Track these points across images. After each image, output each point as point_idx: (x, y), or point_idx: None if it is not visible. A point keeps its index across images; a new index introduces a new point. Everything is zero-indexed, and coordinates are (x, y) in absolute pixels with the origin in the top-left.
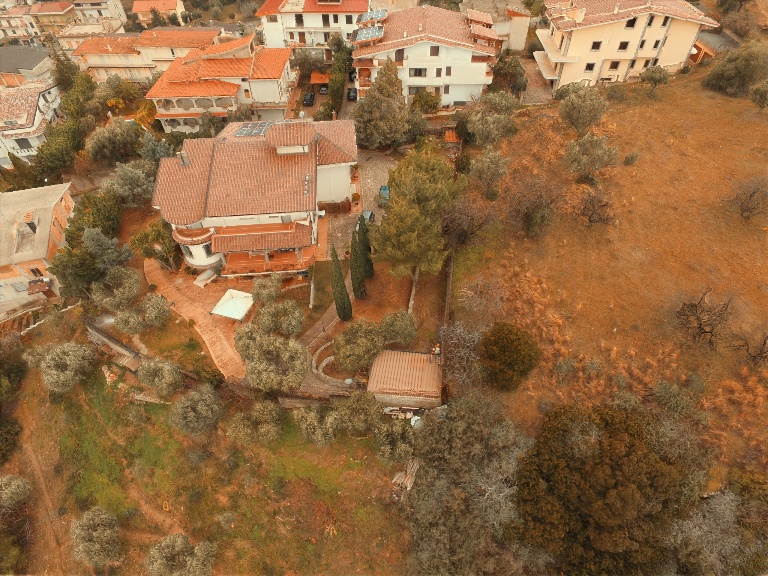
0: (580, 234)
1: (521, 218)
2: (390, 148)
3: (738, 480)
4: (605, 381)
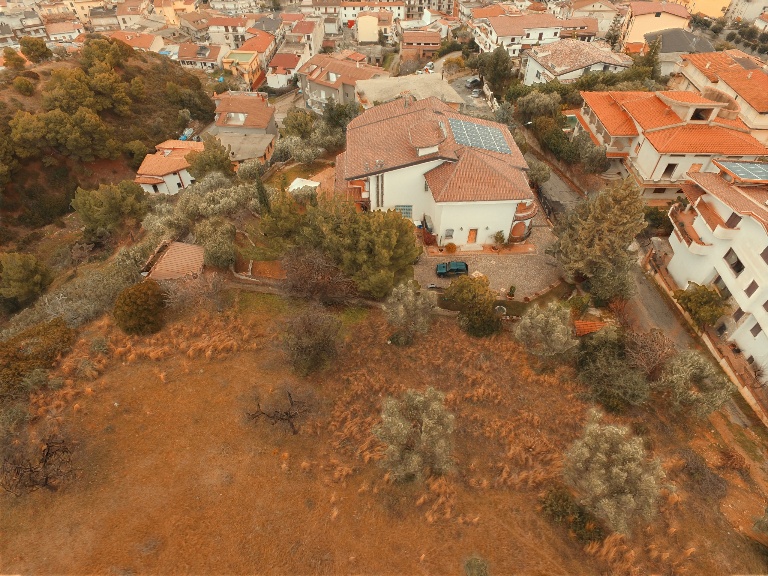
0: None
1: None
2: (580, 282)
3: None
4: (73, 381)
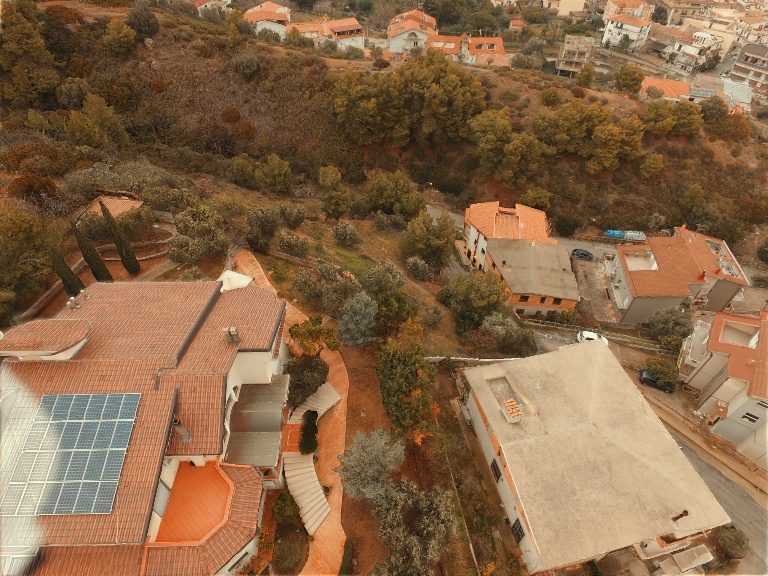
0: None
1: None
2: None
3: None
4: None
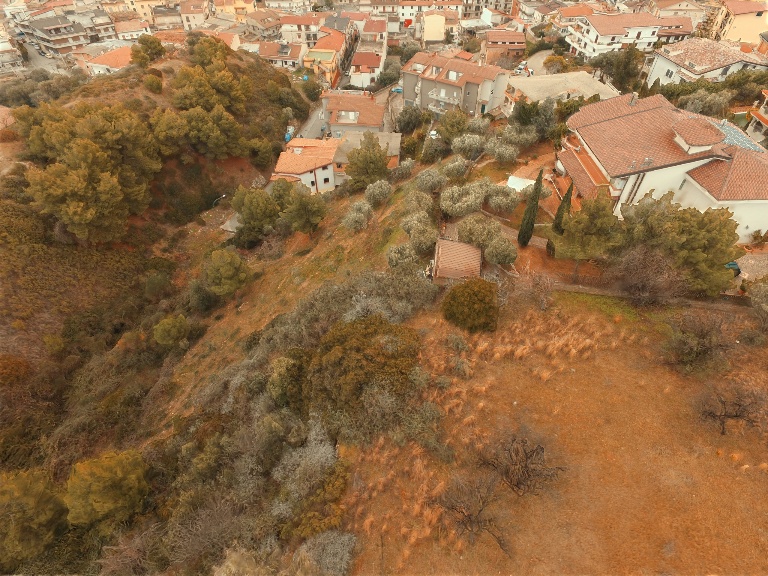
0: None
1: (670, 321)
2: None
3: (340, 462)
4: None
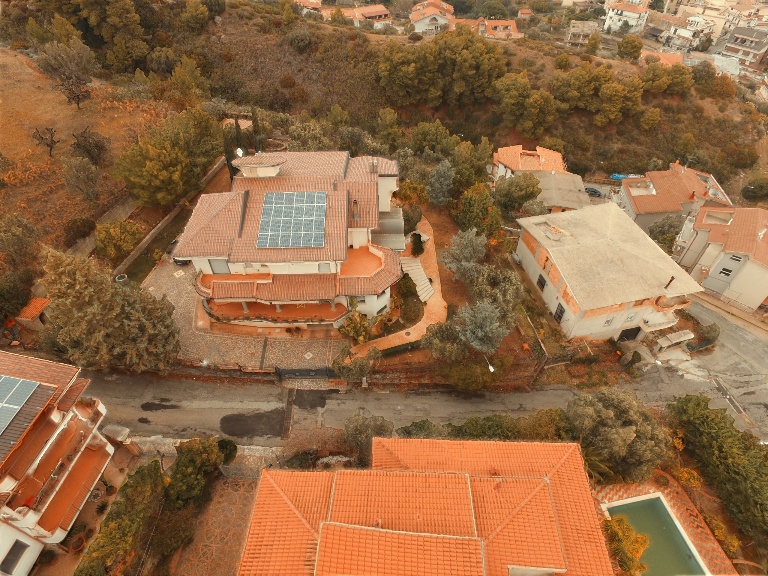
0: (65, 155)
1: None
2: None
3: None
4: None
